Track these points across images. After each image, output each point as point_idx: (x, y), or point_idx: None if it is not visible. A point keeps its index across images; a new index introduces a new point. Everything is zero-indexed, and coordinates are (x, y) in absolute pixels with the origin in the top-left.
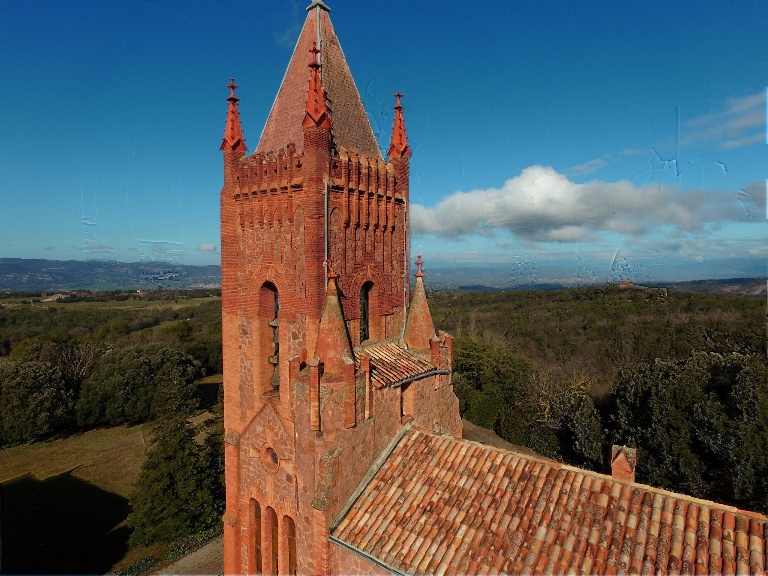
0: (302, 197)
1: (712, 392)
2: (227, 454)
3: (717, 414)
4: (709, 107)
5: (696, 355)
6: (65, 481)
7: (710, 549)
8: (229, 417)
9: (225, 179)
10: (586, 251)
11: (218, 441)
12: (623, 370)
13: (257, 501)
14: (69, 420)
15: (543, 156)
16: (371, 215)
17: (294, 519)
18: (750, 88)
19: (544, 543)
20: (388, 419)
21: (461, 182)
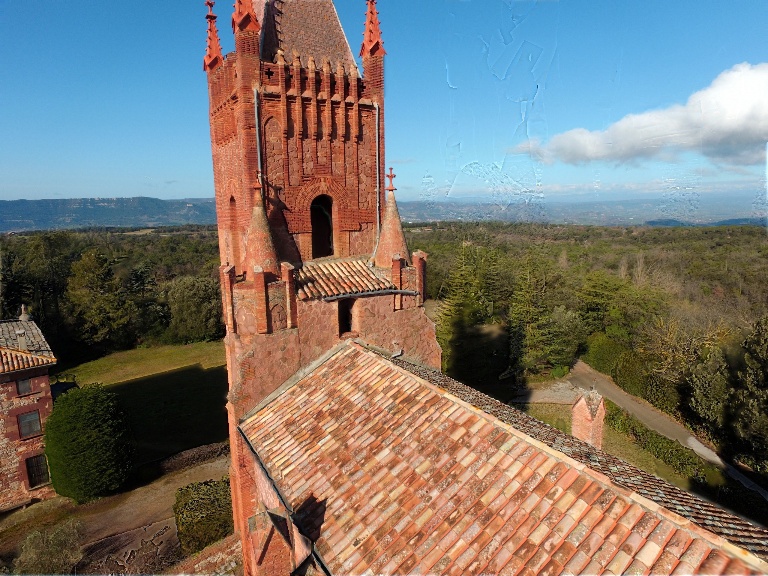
0: (238, 108)
1: None
2: None
3: None
4: None
5: None
6: (219, 372)
7: (523, 503)
8: None
9: None
10: None
11: None
12: (764, 319)
13: None
14: None
15: (727, 45)
16: (324, 124)
17: None
18: None
19: (378, 463)
20: (320, 331)
21: (614, 92)
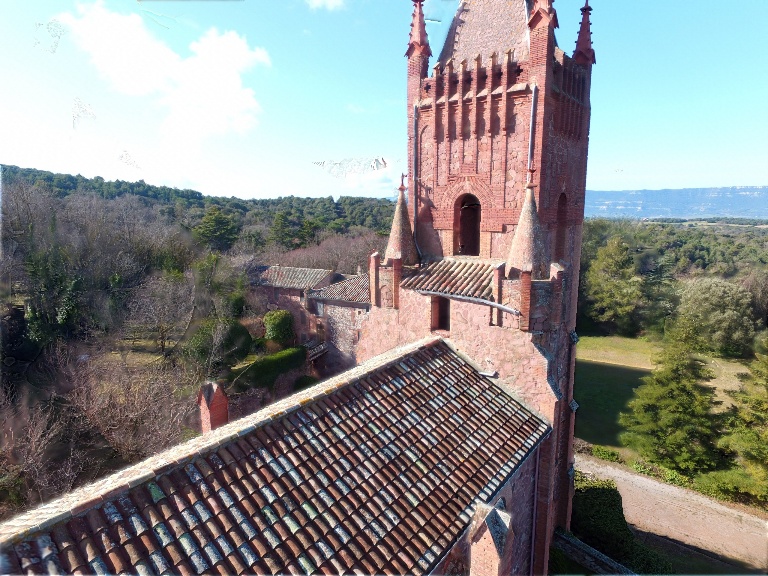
0: None
1: None
2: None
3: None
4: None
5: None
6: None
7: None
8: None
9: None
10: None
11: None
12: None
13: None
14: (748, 348)
15: None
16: None
17: None
18: None
19: None
20: (415, 319)
21: None
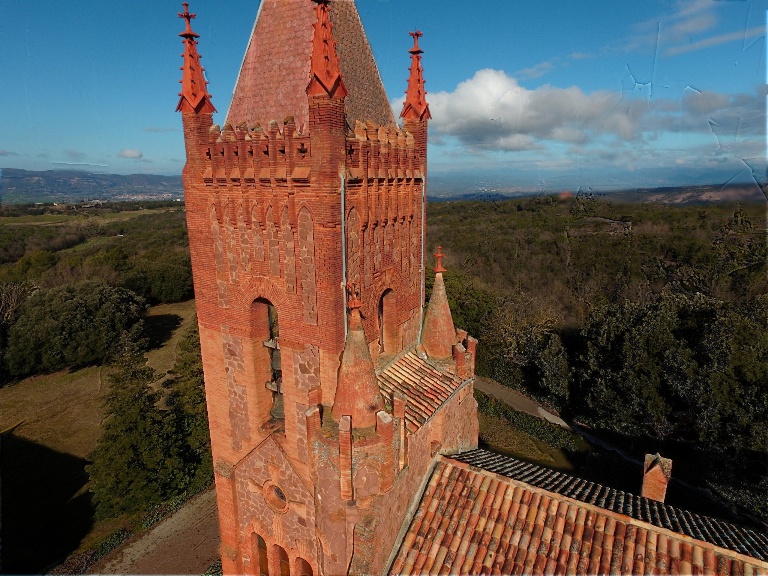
0: (309, 196)
1: (683, 339)
2: (219, 485)
3: (688, 361)
4: (687, 23)
5: (666, 298)
6: (8, 442)
7: None
8: (218, 445)
9: (188, 153)
10: (548, 176)
11: (181, 403)
12: (594, 312)
13: (261, 537)
14: None
15: None
16: (390, 206)
17: (310, 563)
18: (731, 3)
19: None
20: (420, 459)
21: None
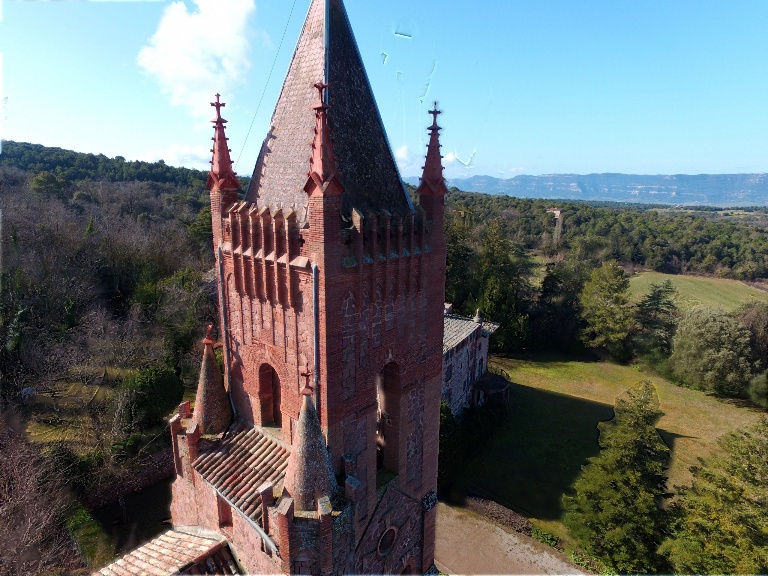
0: None
1: None
2: None
3: None
4: None
5: None
6: None
7: None
8: None
9: None
10: None
11: None
12: None
13: None
14: (743, 391)
15: None
16: None
17: None
18: None
19: None
20: None
21: None
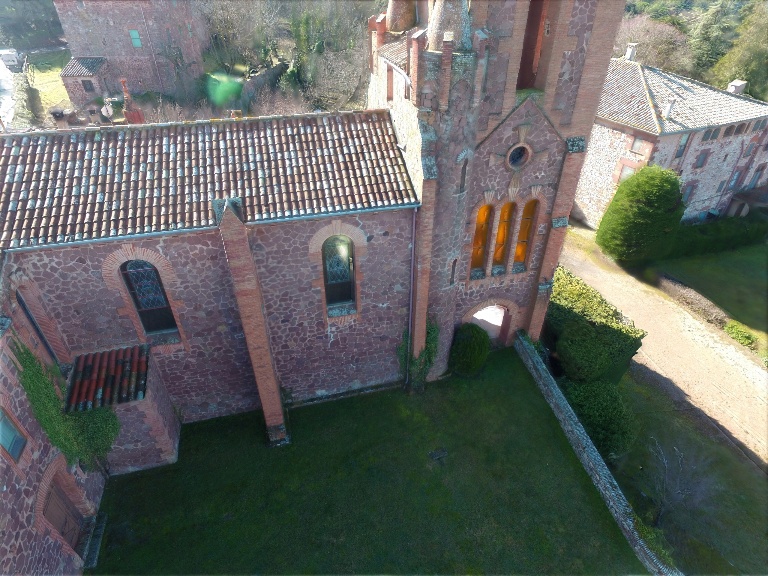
0: None
1: None
2: None
3: None
4: None
5: None
6: None
7: None
8: None
9: None
10: None
11: None
12: None
13: None
14: None
15: None
16: None
17: None
18: None
19: None
20: None
21: None
